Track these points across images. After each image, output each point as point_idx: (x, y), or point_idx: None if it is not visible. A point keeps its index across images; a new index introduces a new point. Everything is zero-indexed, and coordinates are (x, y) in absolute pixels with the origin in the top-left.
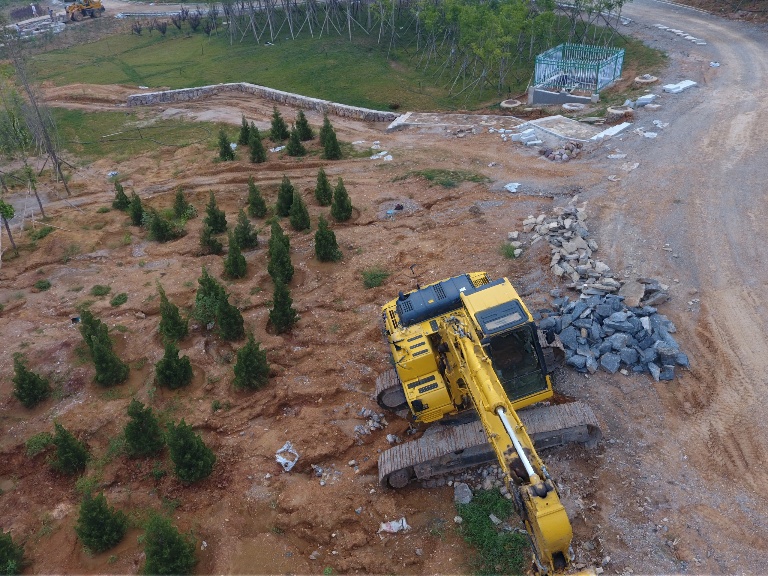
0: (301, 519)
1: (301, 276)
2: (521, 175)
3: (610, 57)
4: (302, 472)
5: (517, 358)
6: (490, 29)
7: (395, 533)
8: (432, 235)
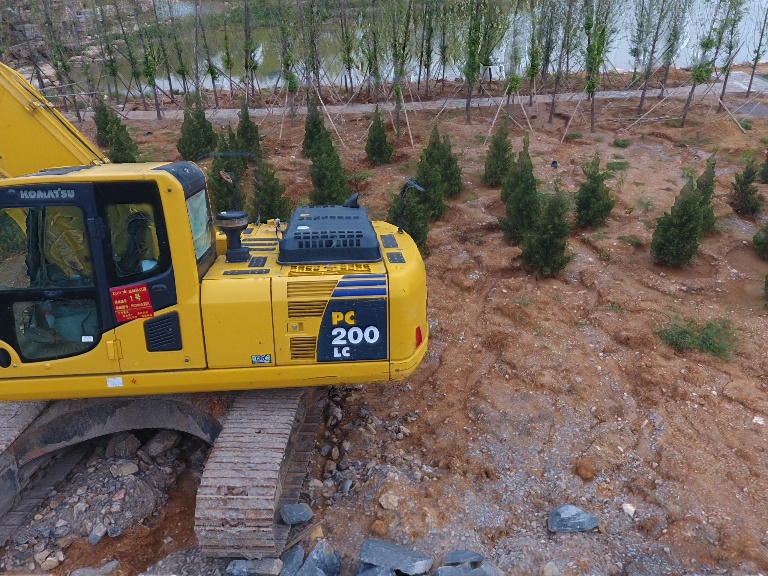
0: None
1: (698, 276)
2: None
3: None
4: None
5: None
6: None
7: None
8: None
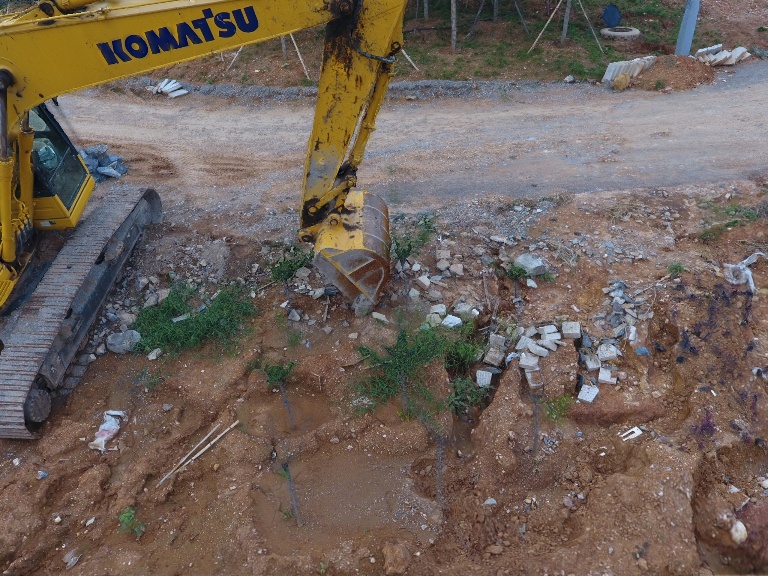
0: None
1: None
2: None
3: None
4: None
5: None
6: None
7: (120, 431)
8: None
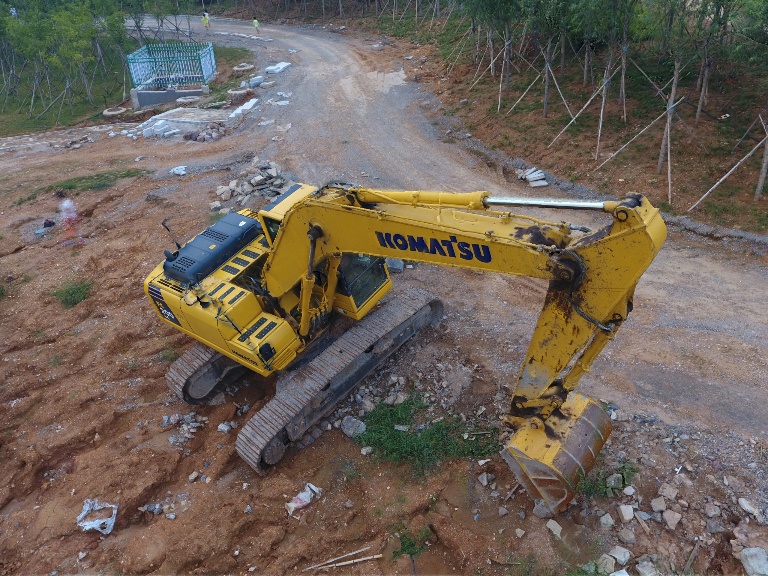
0: (179, 564)
1: None
2: (179, 160)
3: (204, 49)
4: (129, 525)
5: (345, 261)
6: (60, 33)
7: (309, 504)
8: (118, 232)
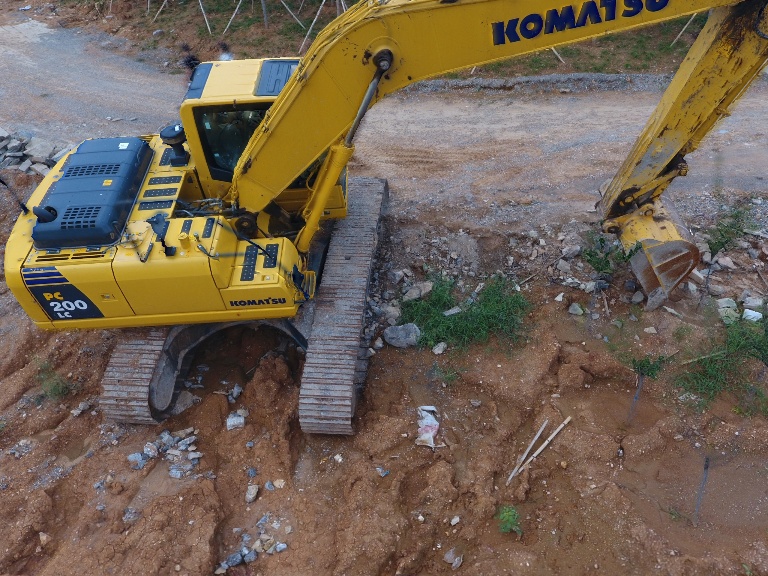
0: None
1: None
2: None
3: None
4: None
5: None
6: None
7: None
8: None
